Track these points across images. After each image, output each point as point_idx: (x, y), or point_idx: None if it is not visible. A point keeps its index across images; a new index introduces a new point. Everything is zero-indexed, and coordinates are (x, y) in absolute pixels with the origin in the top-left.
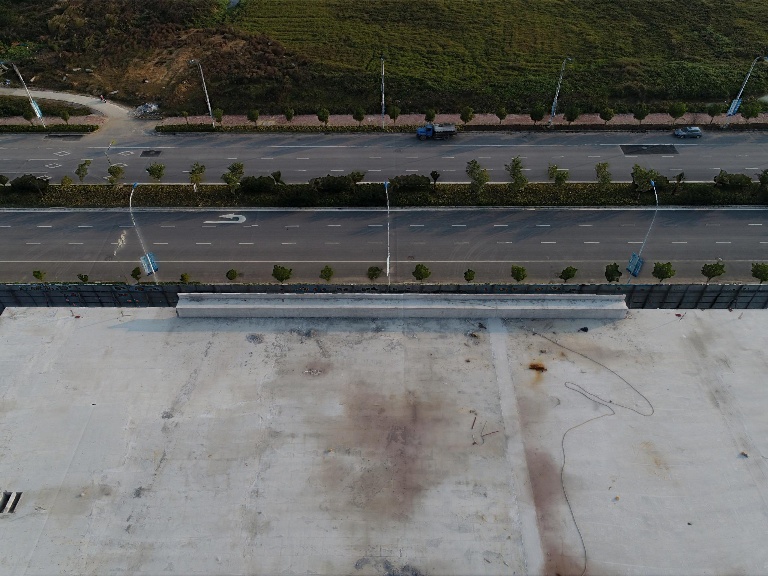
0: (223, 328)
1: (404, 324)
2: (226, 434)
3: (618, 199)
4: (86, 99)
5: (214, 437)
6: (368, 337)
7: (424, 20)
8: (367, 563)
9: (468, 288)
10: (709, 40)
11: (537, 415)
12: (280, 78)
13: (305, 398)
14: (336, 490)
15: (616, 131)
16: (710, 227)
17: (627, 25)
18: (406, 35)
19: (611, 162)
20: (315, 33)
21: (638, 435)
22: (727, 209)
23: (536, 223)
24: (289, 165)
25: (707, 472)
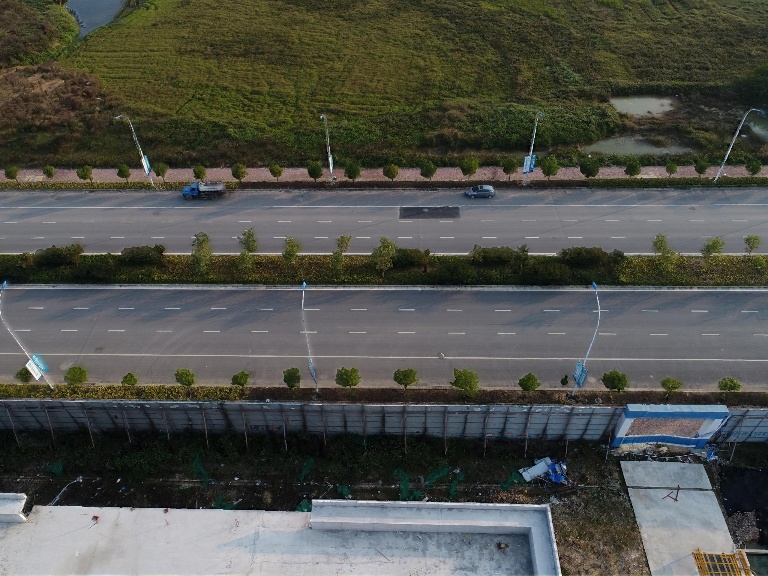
0: None
1: None
2: None
3: (361, 277)
4: None
5: None
6: None
7: (267, 54)
8: None
9: (93, 405)
10: (558, 77)
11: None
12: (74, 125)
13: None
14: None
15: (404, 189)
16: (450, 313)
17: (479, 59)
18: (239, 72)
19: (379, 228)
20: (145, 70)
21: None
22: (480, 290)
23: (258, 306)
24: (29, 231)
25: None
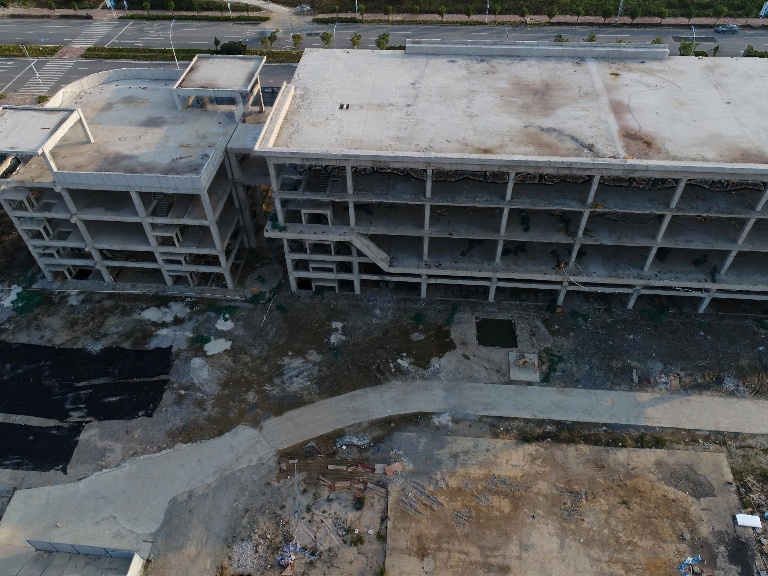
0: (432, 58)
1: (536, 58)
2: (447, 90)
3: None
4: (256, 2)
5: (441, 91)
6: (516, 62)
7: None
8: None
9: None
10: None
11: (615, 89)
12: None
13: (486, 81)
14: (510, 107)
15: (669, 28)
16: None
17: None
18: None
19: None
20: None
21: (671, 96)
22: None
23: None
24: None
25: (707, 107)
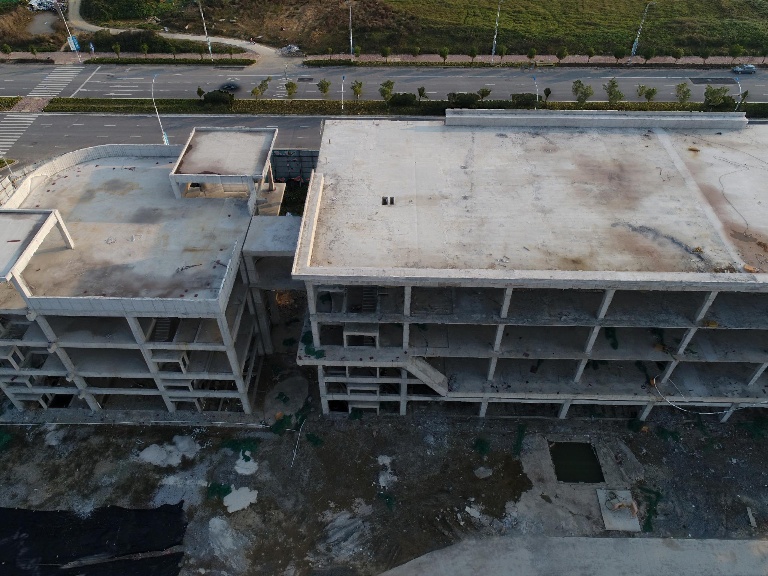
0: (478, 131)
1: (598, 130)
2: (506, 175)
3: None
4: (237, 42)
5: (499, 177)
6: (576, 135)
7: None
8: (618, 225)
9: None
10: (754, 4)
11: (700, 170)
12: (396, 28)
13: (548, 161)
14: (586, 198)
15: (684, 68)
16: None
17: None
18: None
19: None
20: None
21: (766, 178)
22: None
23: None
24: None
25: None
